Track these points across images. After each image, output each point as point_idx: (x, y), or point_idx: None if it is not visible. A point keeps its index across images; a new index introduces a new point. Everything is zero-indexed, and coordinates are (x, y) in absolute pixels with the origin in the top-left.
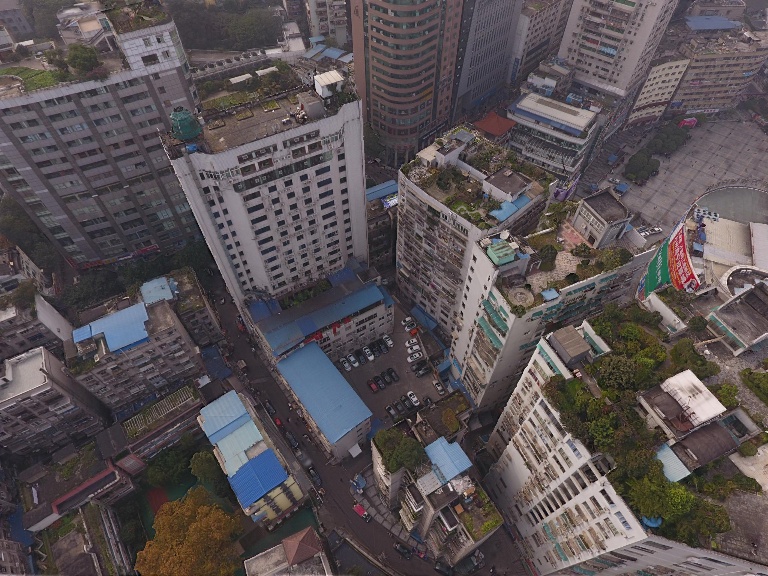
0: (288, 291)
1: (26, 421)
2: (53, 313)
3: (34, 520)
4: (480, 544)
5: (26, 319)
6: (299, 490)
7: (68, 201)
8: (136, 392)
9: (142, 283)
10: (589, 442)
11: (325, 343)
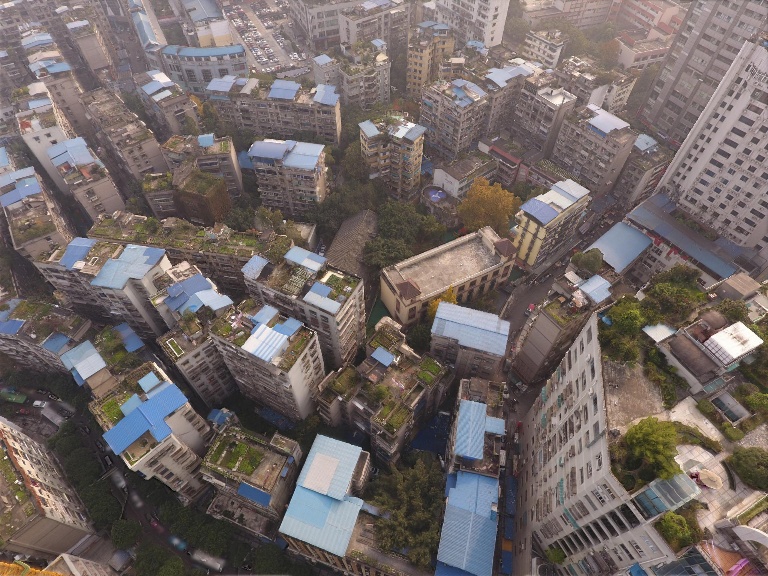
0: (689, 212)
1: (531, 117)
2: (599, 103)
3: (484, 141)
4: (535, 364)
5: (590, 86)
6: (535, 255)
7: (687, 71)
8: (566, 162)
9: (645, 134)
10: (651, 287)
11: (655, 254)
